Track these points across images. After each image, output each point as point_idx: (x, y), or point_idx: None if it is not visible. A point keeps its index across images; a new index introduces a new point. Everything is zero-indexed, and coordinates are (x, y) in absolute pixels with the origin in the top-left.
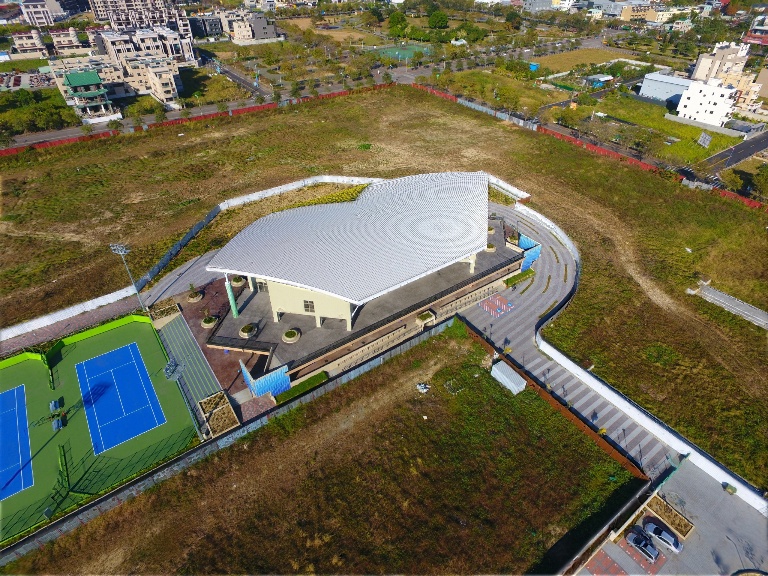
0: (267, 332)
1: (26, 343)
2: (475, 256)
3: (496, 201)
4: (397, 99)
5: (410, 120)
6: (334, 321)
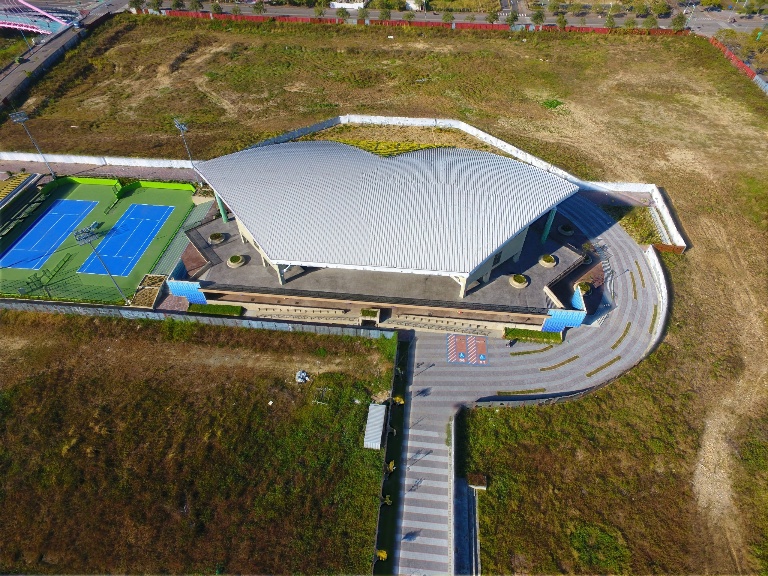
0: (228, 247)
1: (125, 173)
2: (465, 280)
3: (632, 232)
4: (668, 54)
5: (650, 87)
6: None
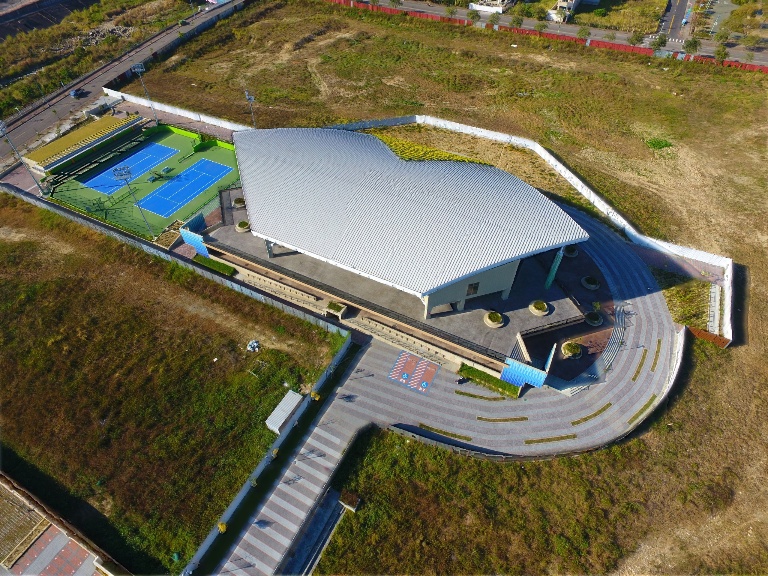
0: (245, 213)
1: (210, 131)
2: (427, 300)
3: (674, 306)
4: None
5: None
6: None
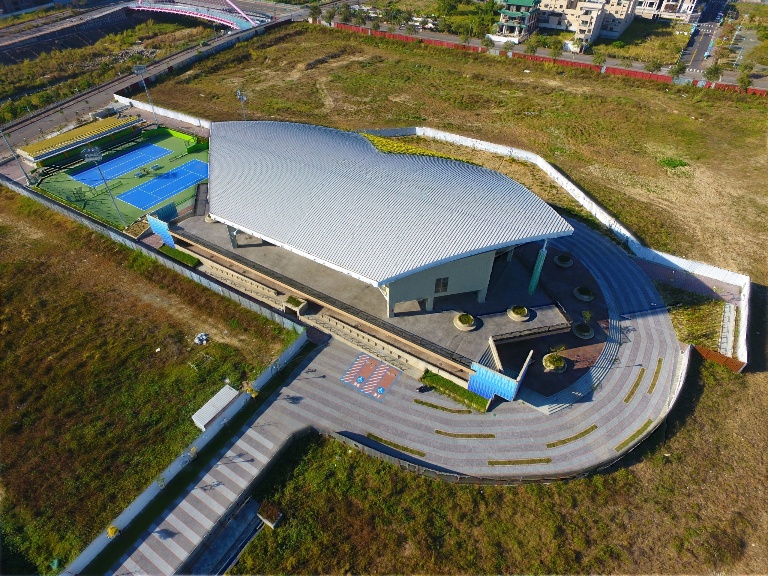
0: None
1: (207, 135)
2: (389, 294)
3: (680, 324)
4: None
5: None
6: (245, 234)
